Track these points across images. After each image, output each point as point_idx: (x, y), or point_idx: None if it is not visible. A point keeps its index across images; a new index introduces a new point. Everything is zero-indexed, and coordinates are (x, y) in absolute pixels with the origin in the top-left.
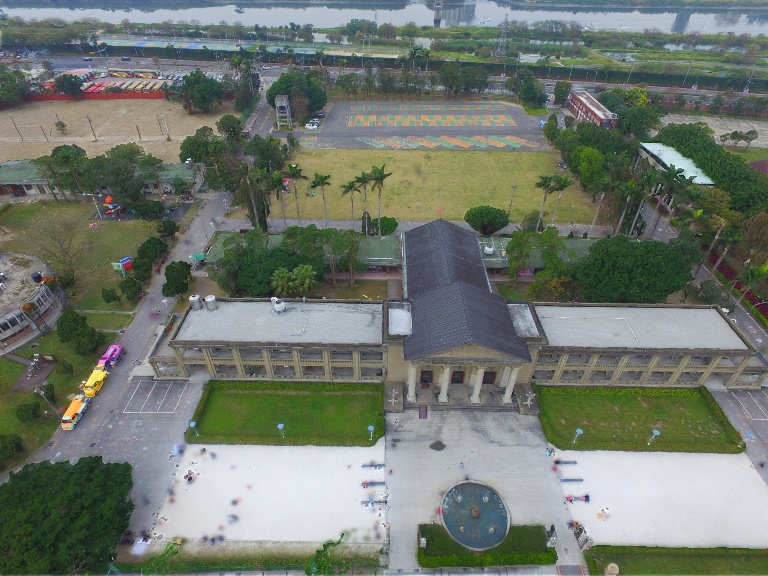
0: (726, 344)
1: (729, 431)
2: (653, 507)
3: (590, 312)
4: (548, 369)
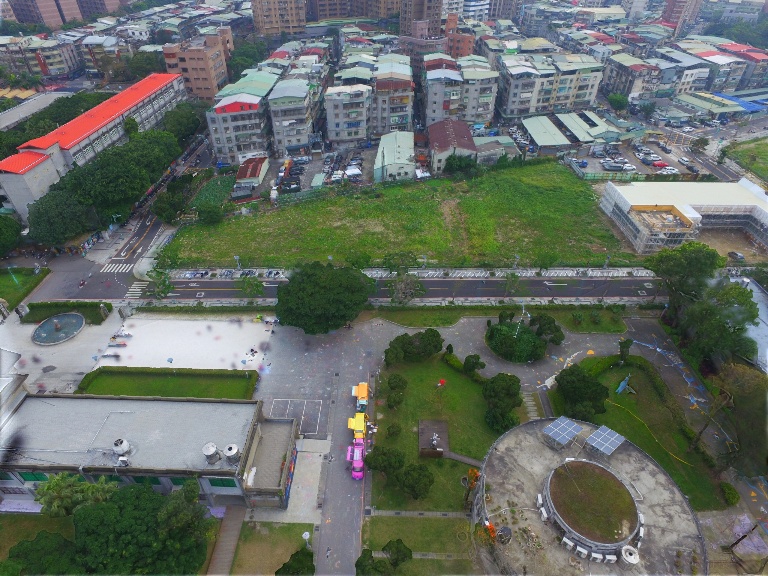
0: None
1: None
2: None
3: None
4: None
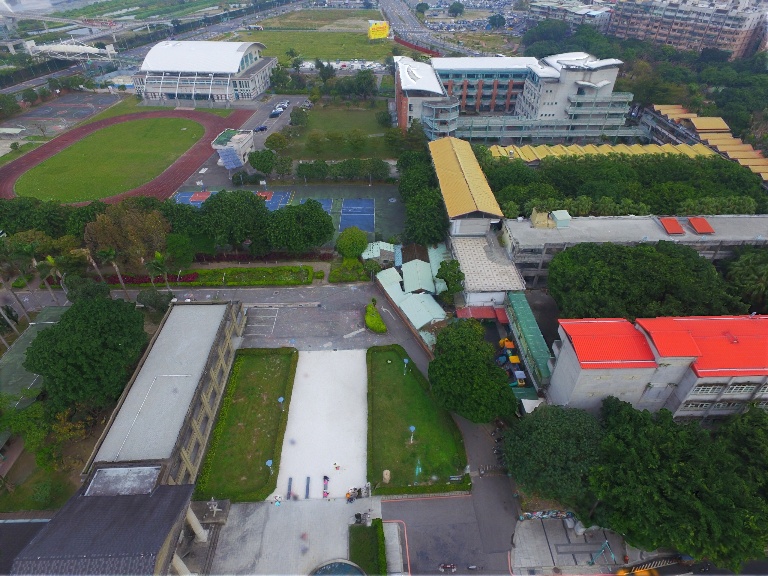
0: (216, 316)
1: (281, 352)
2: (335, 428)
3: (132, 404)
4: (183, 474)
